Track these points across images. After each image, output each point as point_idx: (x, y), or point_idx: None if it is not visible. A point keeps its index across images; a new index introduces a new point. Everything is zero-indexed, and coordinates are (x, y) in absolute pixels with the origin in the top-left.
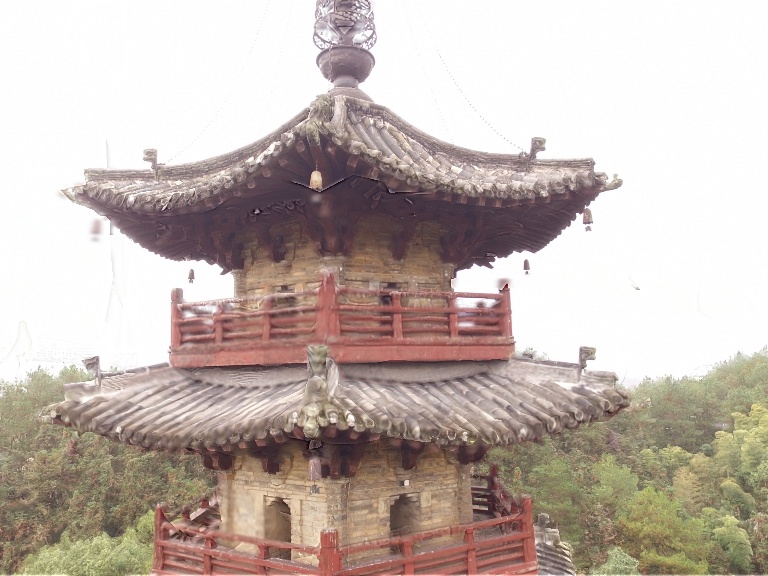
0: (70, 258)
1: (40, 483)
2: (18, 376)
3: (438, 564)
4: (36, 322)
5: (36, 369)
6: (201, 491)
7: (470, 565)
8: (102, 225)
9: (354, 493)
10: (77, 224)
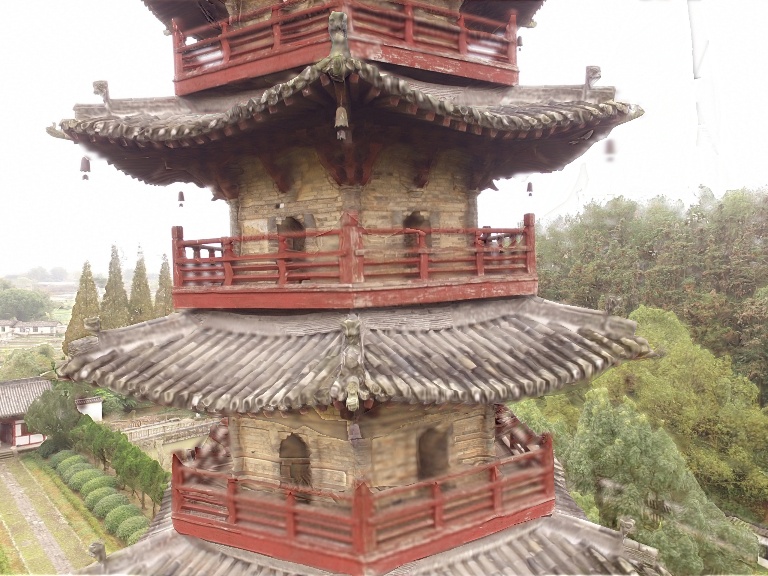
0: (654, 110)
1: (578, 289)
2: (579, 210)
3: (249, 40)
4: (626, 176)
5: (590, 201)
6: (715, 301)
7: (276, 39)
8: (684, 69)
9: (246, 15)
10: (659, 74)
